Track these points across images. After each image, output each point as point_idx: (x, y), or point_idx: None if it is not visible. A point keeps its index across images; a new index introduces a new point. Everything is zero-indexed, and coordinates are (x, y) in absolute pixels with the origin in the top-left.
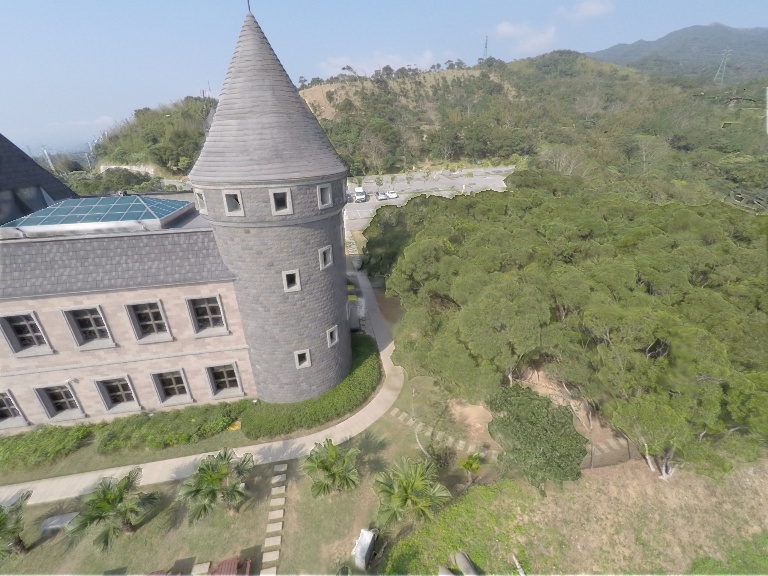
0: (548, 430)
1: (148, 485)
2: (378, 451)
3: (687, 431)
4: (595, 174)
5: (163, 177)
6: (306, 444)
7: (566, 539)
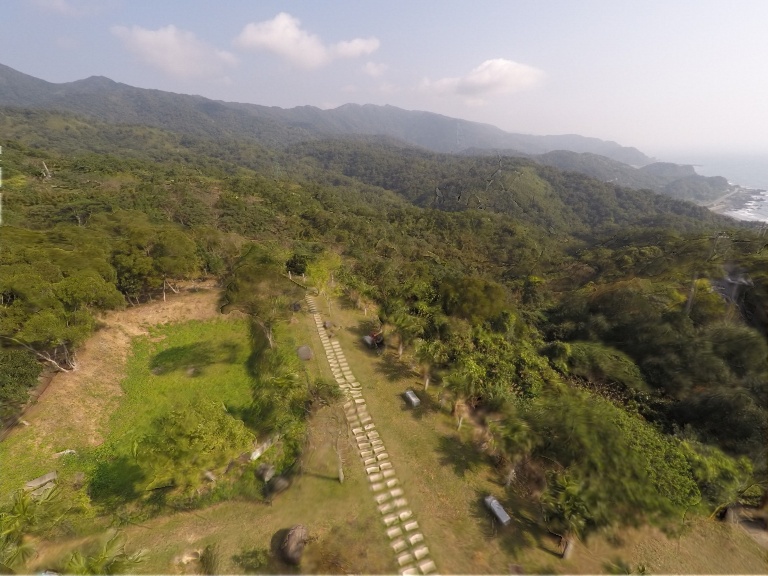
0: (1, 364)
1: None
2: None
3: (61, 327)
4: None
5: None
6: None
7: (69, 425)
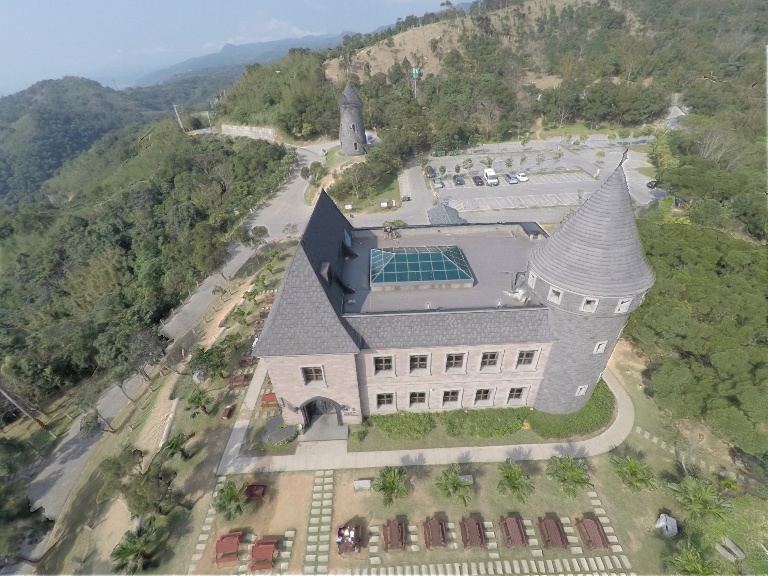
0: None
1: (497, 462)
2: (640, 460)
3: None
4: (750, 159)
5: (296, 147)
6: (586, 447)
7: None
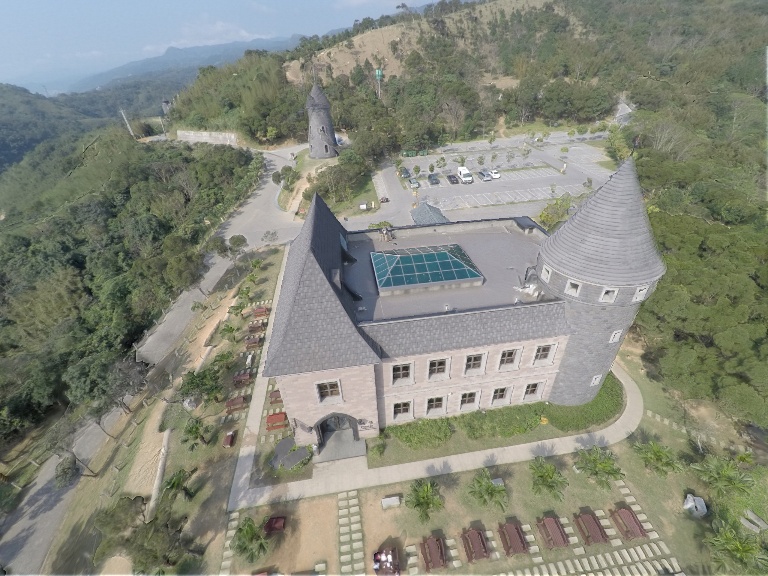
0: None
1: (523, 462)
2: (657, 443)
3: None
4: (697, 150)
5: (263, 152)
6: (605, 436)
7: None
